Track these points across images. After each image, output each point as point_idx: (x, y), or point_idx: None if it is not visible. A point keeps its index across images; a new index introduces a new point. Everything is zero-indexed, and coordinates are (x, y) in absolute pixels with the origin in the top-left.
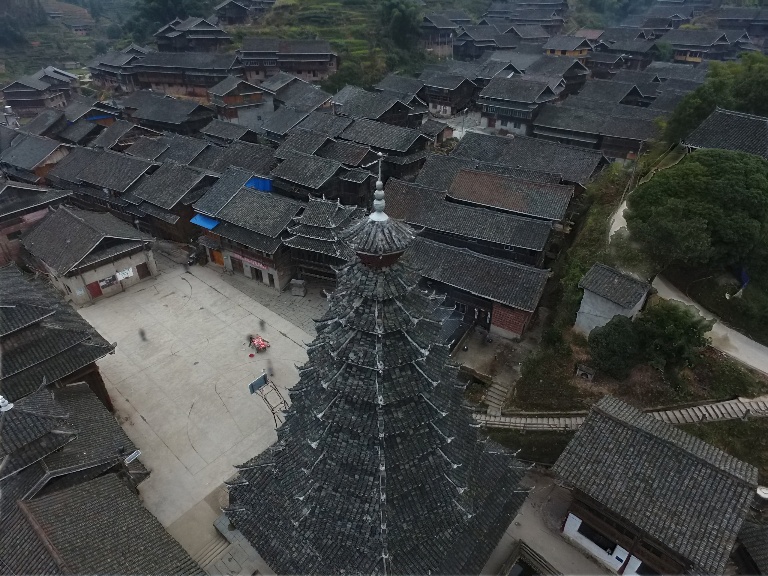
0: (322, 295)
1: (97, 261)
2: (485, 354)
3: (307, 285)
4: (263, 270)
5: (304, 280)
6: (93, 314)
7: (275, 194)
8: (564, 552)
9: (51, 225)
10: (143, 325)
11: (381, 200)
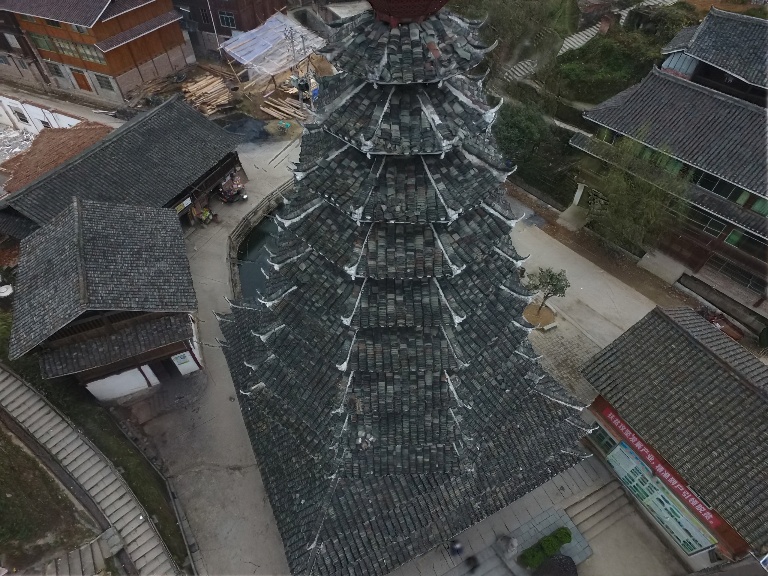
0: None
1: None
2: None
3: None
4: None
5: None
6: None
7: None
8: (216, 360)
9: None
10: None
11: None
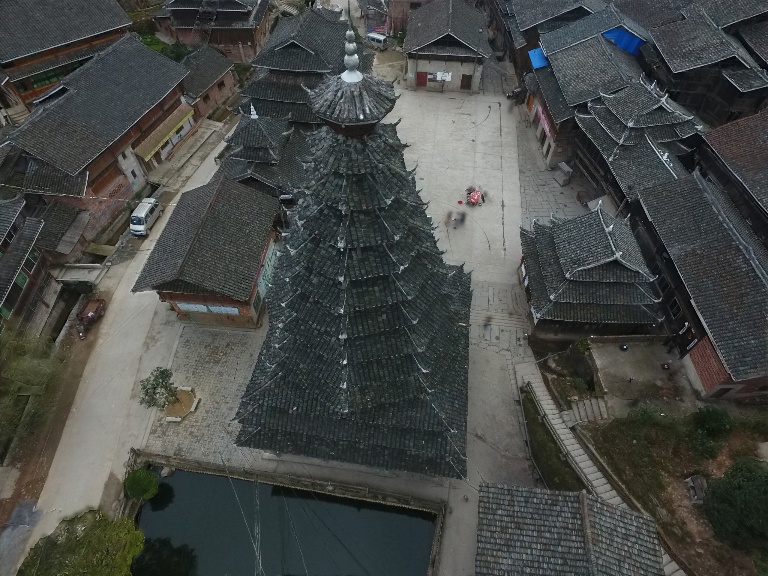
0: (578, 196)
1: (433, 54)
2: (638, 371)
3: (577, 178)
4: (548, 137)
5: (573, 170)
6: (407, 98)
7: (633, 60)
8: (469, 556)
9: (434, 6)
10: (424, 127)
11: (350, 56)
